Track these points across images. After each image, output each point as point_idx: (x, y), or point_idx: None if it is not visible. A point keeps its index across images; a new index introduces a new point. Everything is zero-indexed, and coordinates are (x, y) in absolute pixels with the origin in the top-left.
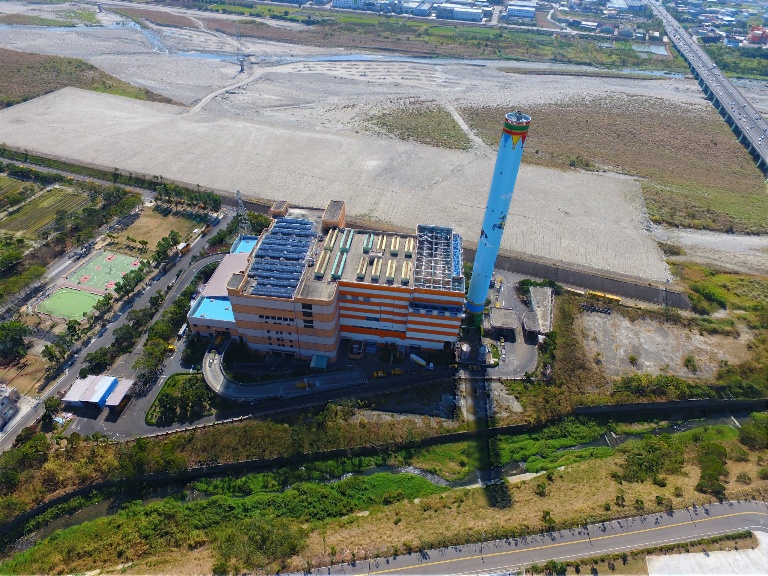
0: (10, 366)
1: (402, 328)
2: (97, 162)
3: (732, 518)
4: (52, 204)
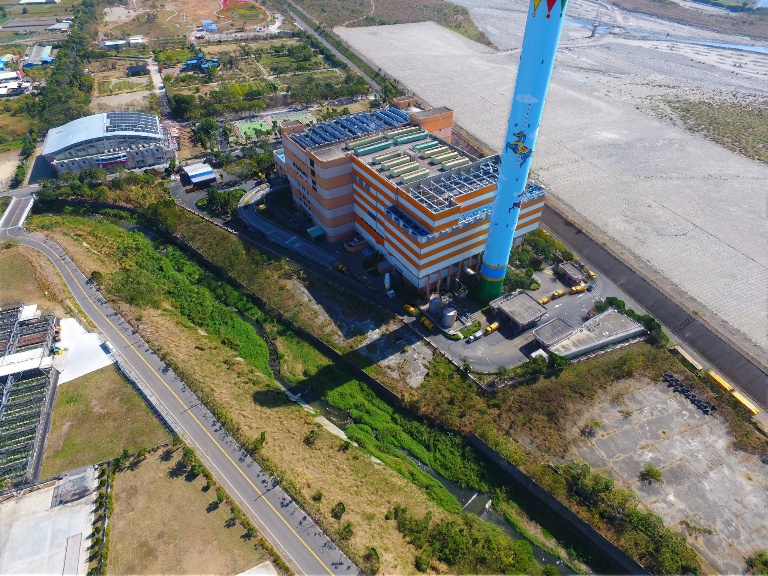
0: (192, 143)
1: None
2: (382, 66)
3: None
4: (319, 77)
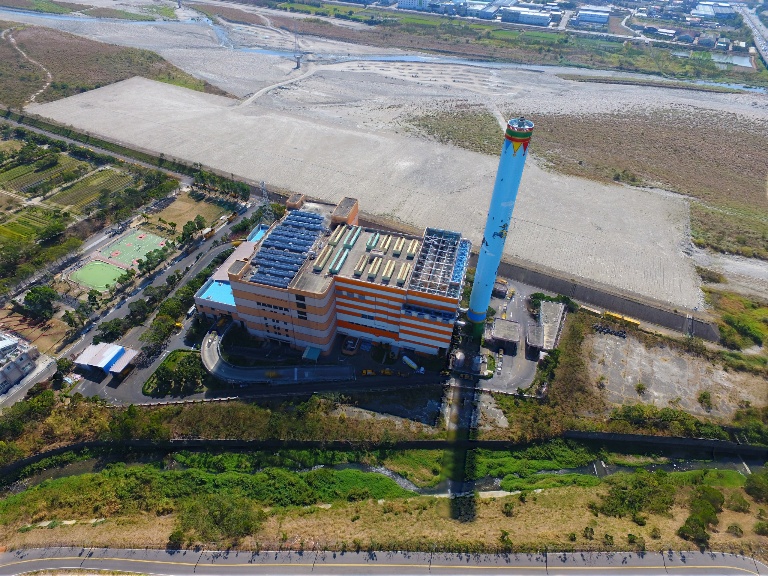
0: (37, 326)
1: (396, 329)
2: (148, 147)
3: (711, 570)
4: (100, 183)
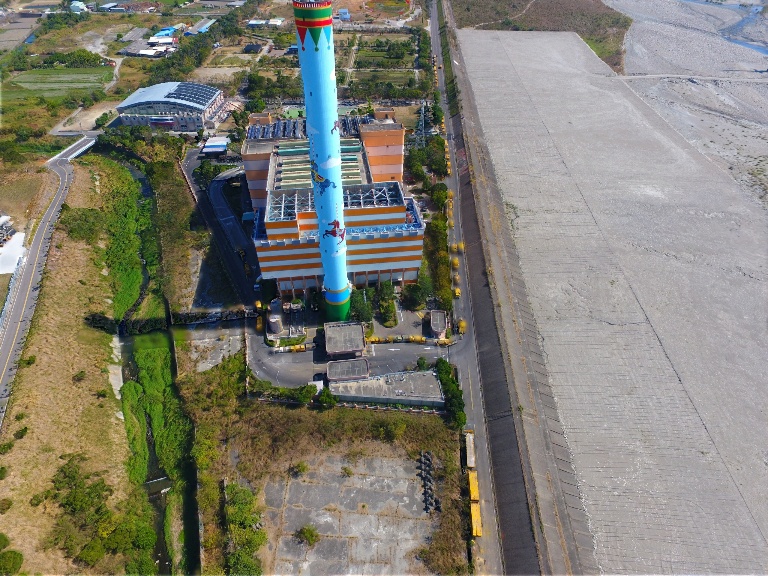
0: None
1: None
2: (470, 74)
3: None
4: (393, 76)
